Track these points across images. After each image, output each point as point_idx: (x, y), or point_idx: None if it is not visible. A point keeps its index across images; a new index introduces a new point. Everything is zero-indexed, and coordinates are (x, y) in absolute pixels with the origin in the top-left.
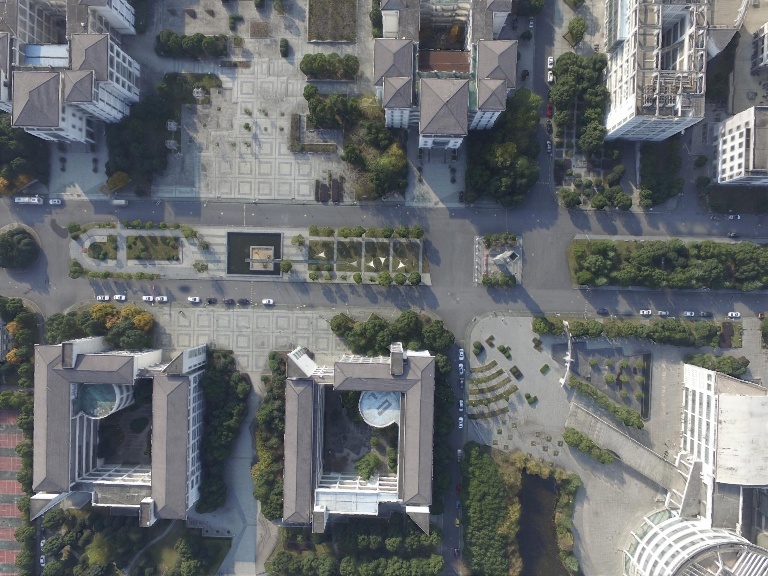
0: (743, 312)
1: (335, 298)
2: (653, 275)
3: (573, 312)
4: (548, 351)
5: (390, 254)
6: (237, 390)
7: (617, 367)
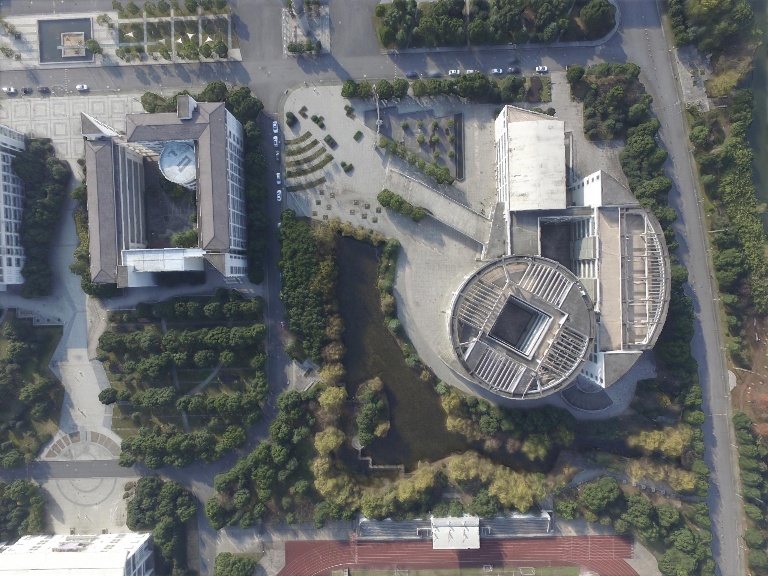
0: (551, 66)
1: (148, 80)
2: (449, 23)
3: (383, 78)
4: (360, 118)
5: (199, 32)
6: (53, 172)
7: (429, 129)
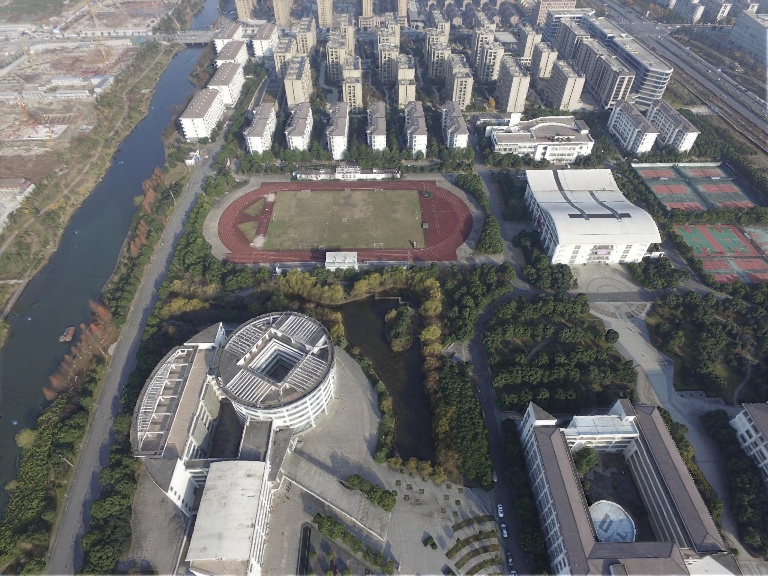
0: None
1: None
2: None
3: None
4: None
5: None
6: None
7: None
